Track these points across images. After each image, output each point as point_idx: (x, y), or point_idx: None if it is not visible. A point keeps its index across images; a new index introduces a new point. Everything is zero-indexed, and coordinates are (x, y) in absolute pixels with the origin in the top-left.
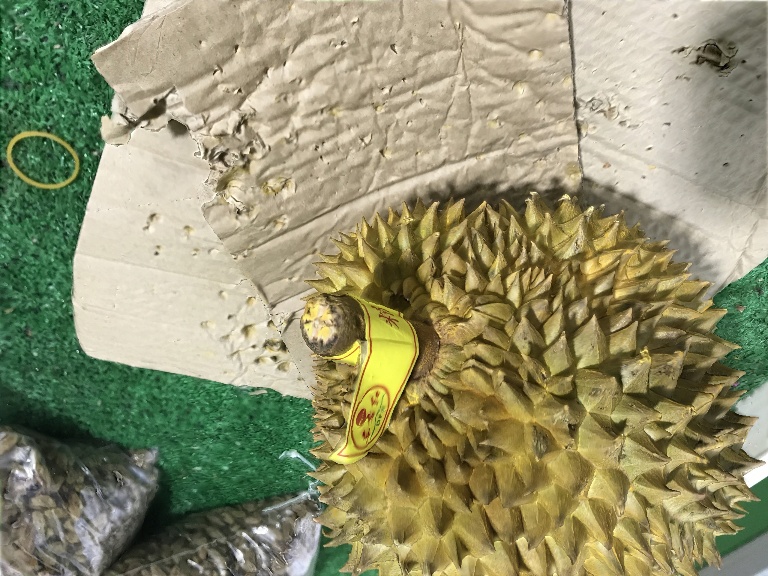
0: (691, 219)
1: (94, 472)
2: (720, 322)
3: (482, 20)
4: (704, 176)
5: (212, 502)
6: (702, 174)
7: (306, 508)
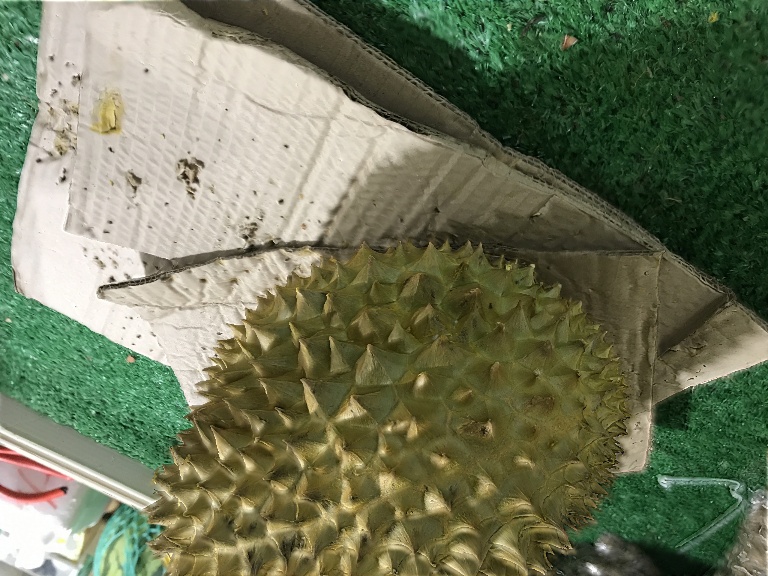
0: (351, 169)
1: (568, 572)
2: (599, 64)
3: (192, 299)
4: (302, 161)
5: (721, 543)
6: (300, 163)
7: (760, 513)
